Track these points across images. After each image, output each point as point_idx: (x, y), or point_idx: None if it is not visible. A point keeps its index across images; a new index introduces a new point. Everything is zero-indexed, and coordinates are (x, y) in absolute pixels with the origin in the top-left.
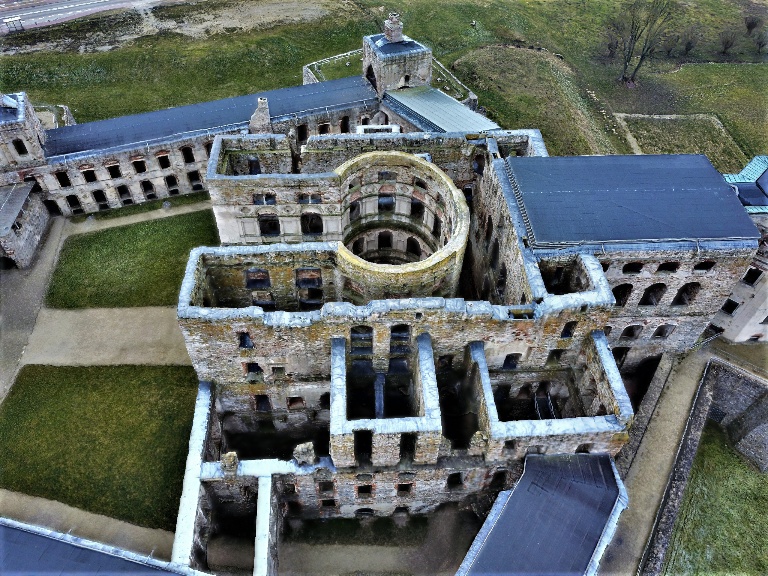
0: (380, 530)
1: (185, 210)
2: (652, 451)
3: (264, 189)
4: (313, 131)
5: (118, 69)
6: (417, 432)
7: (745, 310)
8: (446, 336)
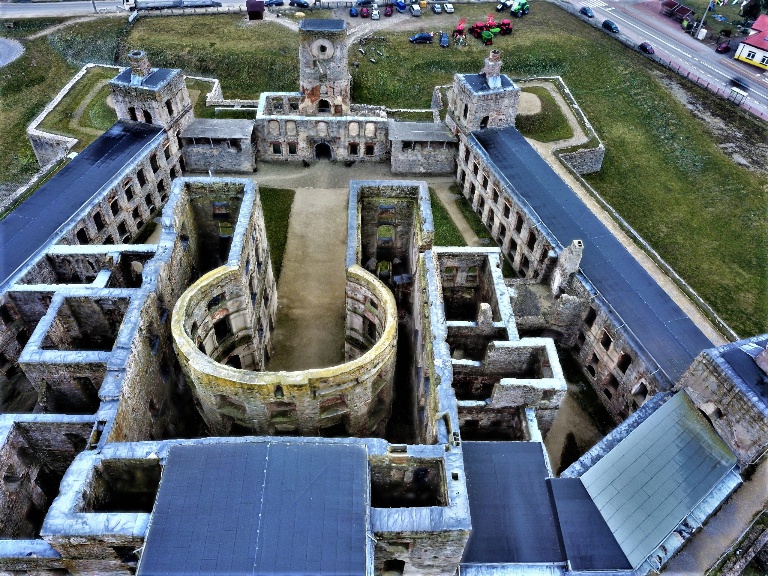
0: None
1: None
2: None
3: None
4: (597, 328)
5: (709, 176)
6: None
7: None
8: None
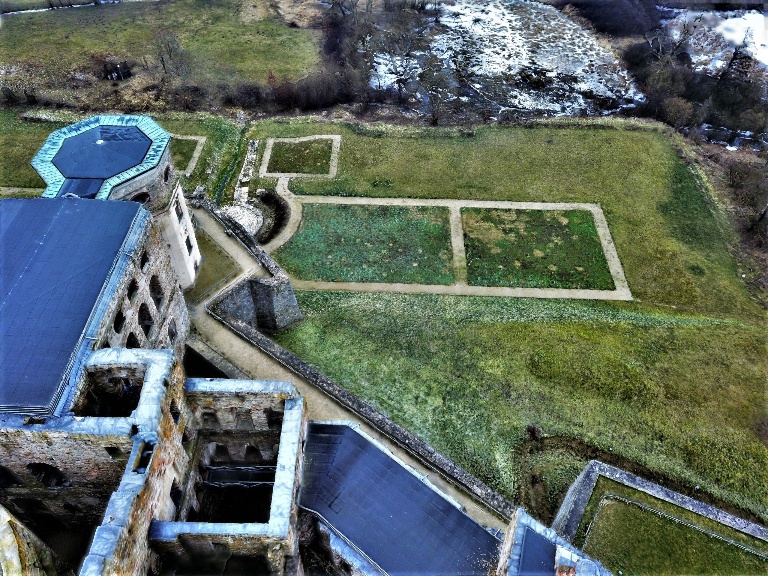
0: None
1: None
2: None
3: None
4: None
5: None
6: None
7: (175, 259)
8: (132, 569)
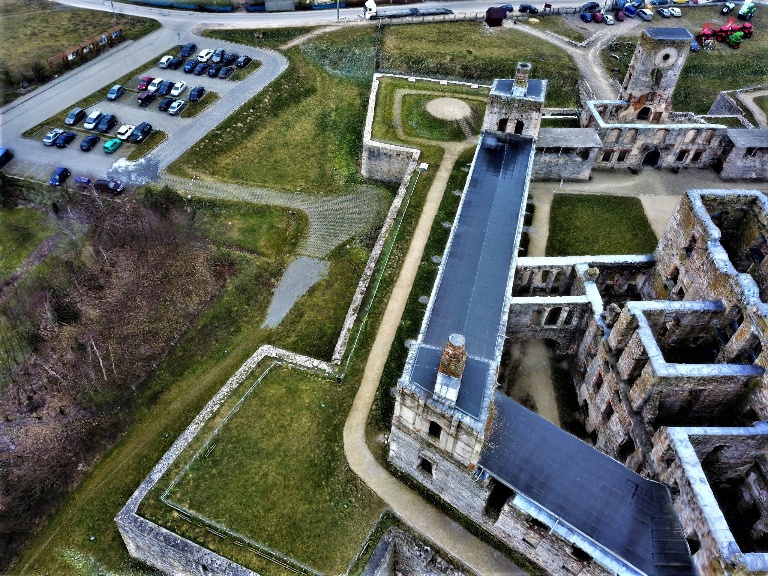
0: (574, 427)
1: None
2: None
3: None
4: None
5: None
6: (649, 358)
7: None
8: None
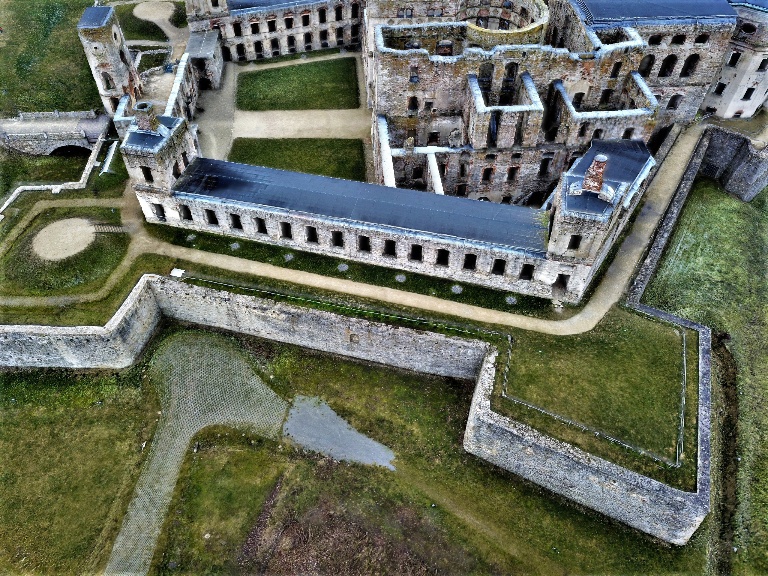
0: None
1: (318, 59)
2: (669, 170)
3: (406, 4)
4: None
5: None
6: (529, 111)
7: (730, 89)
8: (538, 74)
